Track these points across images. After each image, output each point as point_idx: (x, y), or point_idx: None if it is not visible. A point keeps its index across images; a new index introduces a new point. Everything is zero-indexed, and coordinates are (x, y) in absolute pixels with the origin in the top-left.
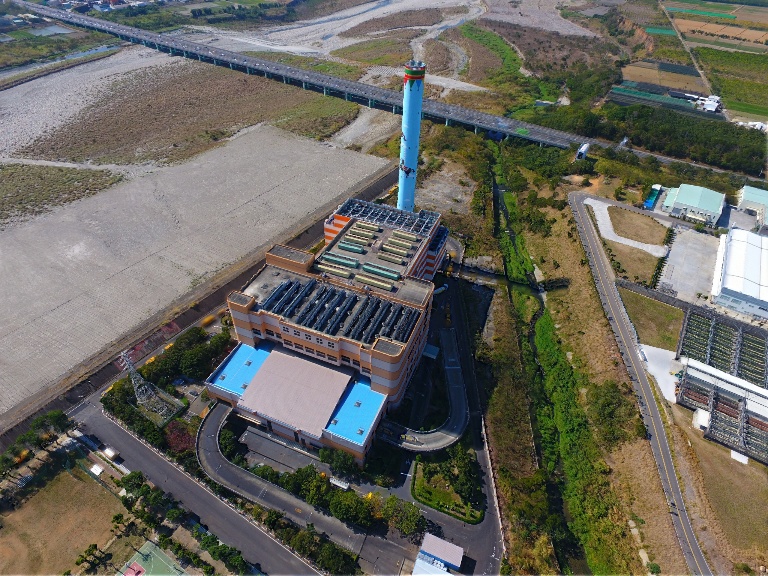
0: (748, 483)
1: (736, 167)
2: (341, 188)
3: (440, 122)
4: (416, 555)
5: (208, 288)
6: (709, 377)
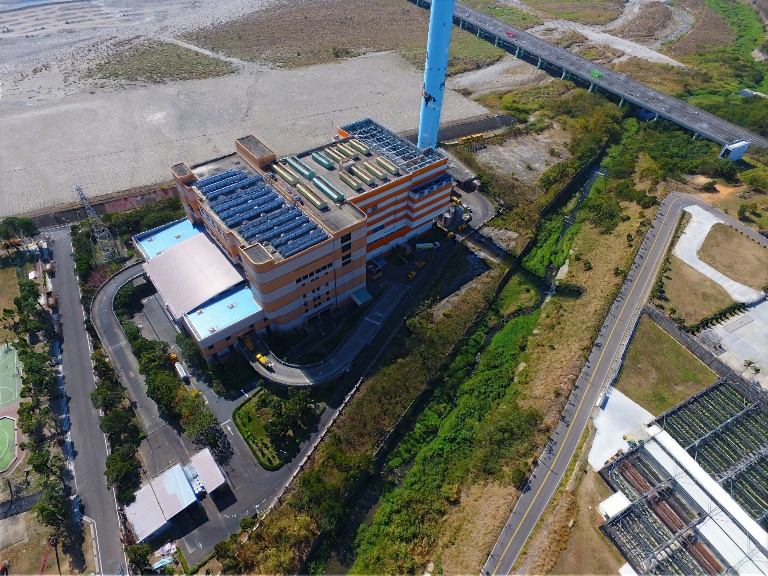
0: None
1: None
2: (415, 124)
3: (585, 87)
4: None
5: None
6: (673, 465)
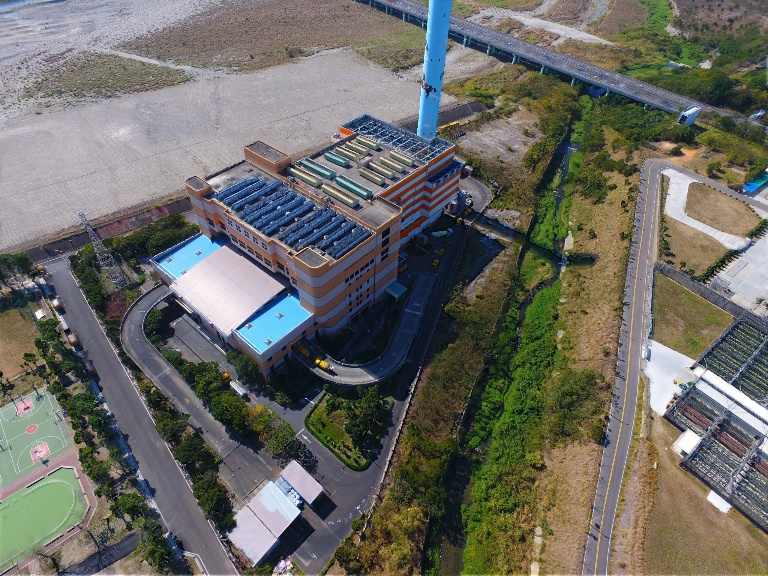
0: (714, 535)
1: None
2: (390, 118)
3: (536, 69)
4: None
5: None
6: (724, 398)
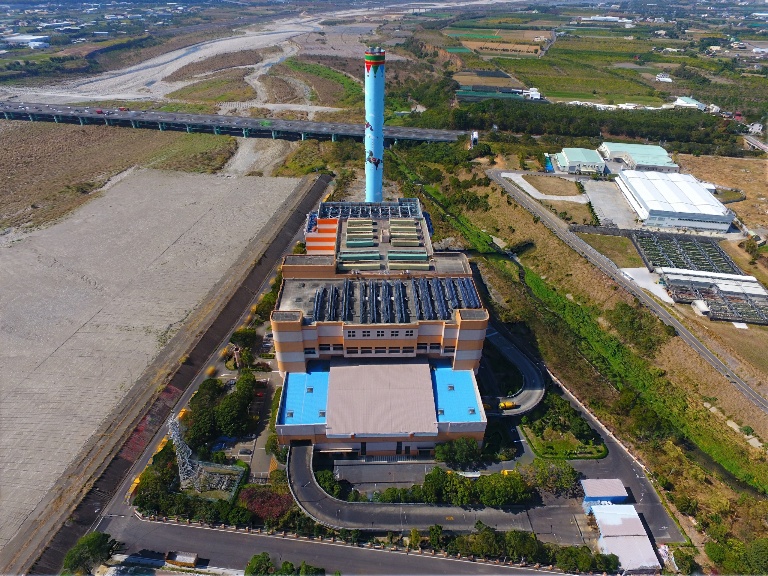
0: (759, 341)
1: (582, 134)
2: (269, 211)
3: (325, 139)
4: (581, 507)
5: (188, 338)
6: (683, 276)
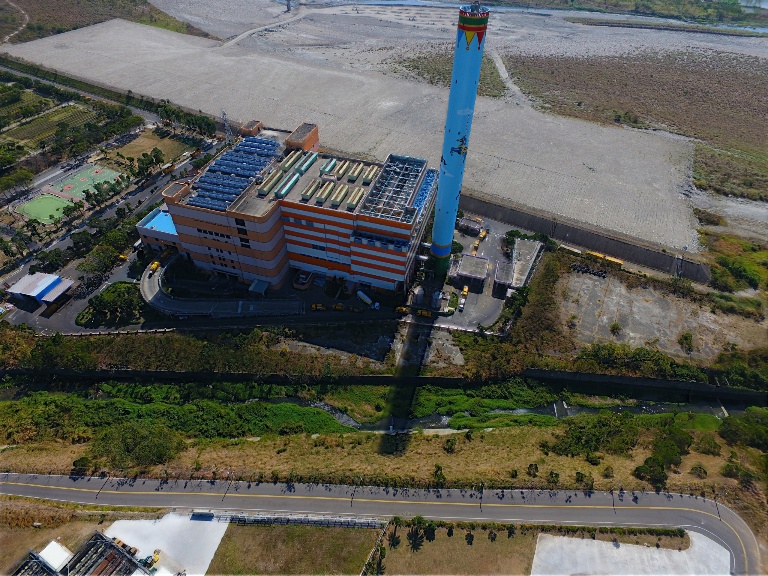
0: None
1: None
2: (570, 212)
3: None
4: None
5: None
6: None
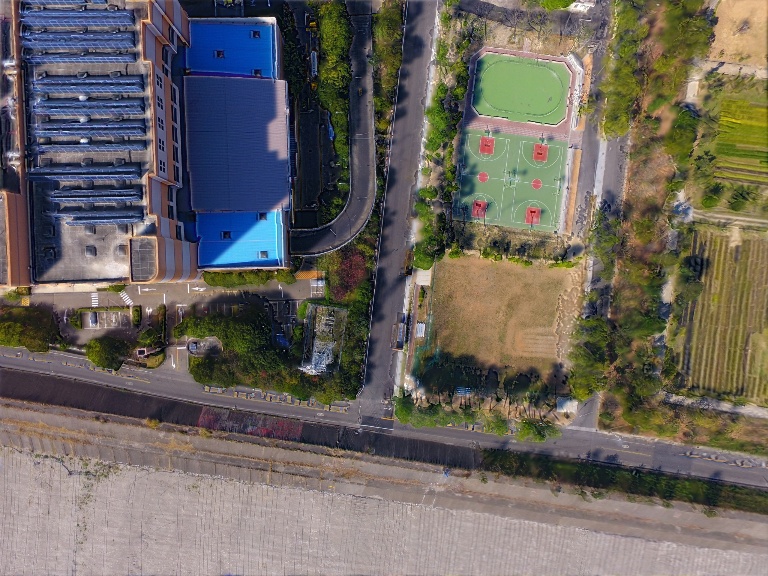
0: None
1: None
2: None
3: None
4: None
5: (107, 434)
6: None
